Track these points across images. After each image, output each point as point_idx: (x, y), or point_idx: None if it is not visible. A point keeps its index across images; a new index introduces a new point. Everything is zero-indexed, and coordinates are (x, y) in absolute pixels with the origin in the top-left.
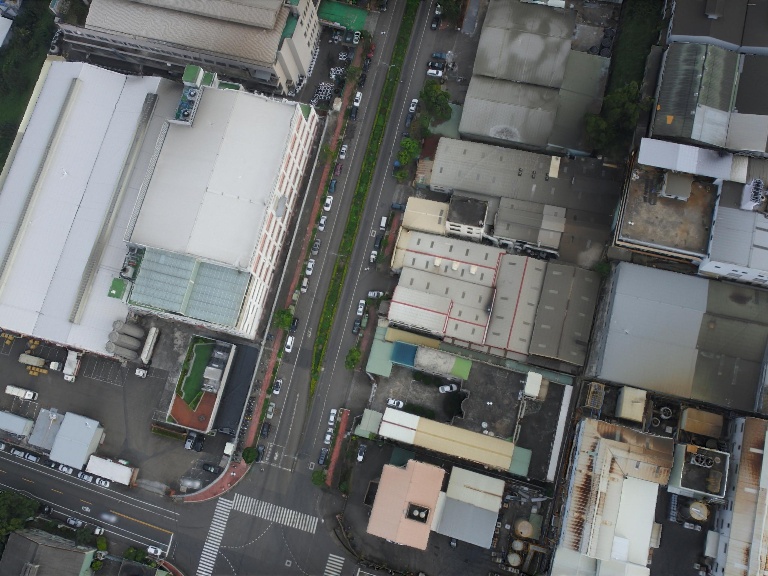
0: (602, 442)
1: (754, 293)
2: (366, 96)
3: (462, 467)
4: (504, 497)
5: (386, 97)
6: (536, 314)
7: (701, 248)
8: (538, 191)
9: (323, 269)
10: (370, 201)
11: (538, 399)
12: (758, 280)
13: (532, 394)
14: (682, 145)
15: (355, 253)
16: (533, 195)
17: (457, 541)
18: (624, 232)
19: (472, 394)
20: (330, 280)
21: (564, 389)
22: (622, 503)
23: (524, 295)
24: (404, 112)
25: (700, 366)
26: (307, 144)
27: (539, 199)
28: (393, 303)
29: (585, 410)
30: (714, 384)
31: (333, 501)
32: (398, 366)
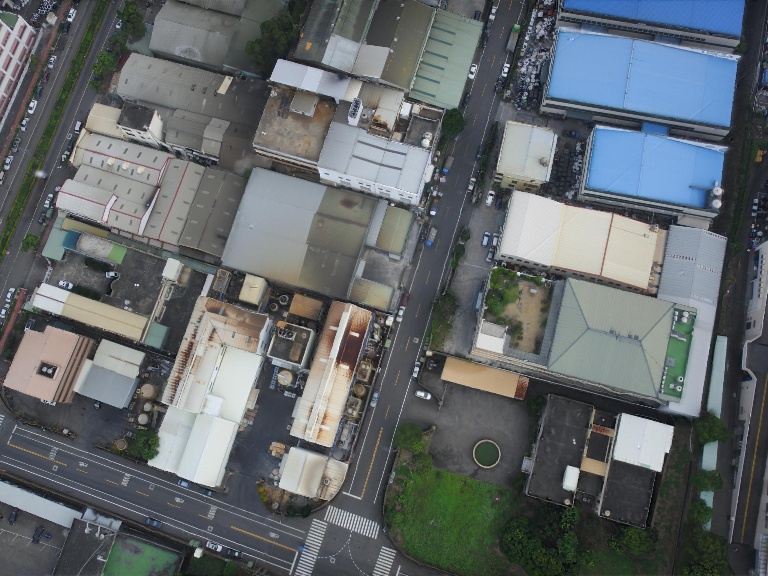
0: (205, 315)
1: (362, 200)
2: (80, 13)
3: (111, 340)
4: (147, 368)
5: (94, 15)
6: (190, 211)
7: (317, 157)
8: (208, 105)
9: (20, 165)
10: (70, 107)
11: (179, 284)
12: (365, 189)
13: (168, 277)
14: (310, 67)
15: (51, 153)
16: (203, 108)
17: (101, 403)
18: (256, 140)
19: (123, 276)
20: (25, 175)
21: (206, 277)
22: (226, 370)
23: (181, 194)
24: (112, 30)
25: (308, 259)
26: (17, 52)
27: (208, 112)
28: (61, 193)
29: (215, 294)
30: (317, 274)
31: (0, 367)
32: (74, 253)
